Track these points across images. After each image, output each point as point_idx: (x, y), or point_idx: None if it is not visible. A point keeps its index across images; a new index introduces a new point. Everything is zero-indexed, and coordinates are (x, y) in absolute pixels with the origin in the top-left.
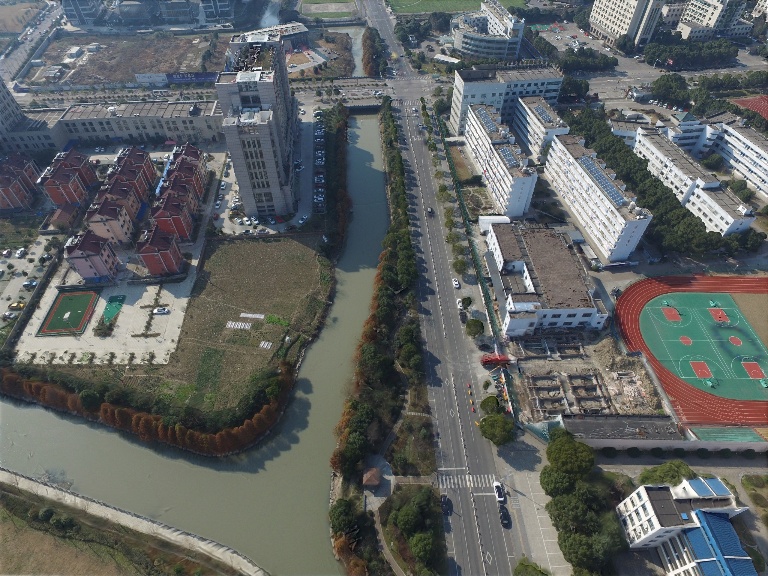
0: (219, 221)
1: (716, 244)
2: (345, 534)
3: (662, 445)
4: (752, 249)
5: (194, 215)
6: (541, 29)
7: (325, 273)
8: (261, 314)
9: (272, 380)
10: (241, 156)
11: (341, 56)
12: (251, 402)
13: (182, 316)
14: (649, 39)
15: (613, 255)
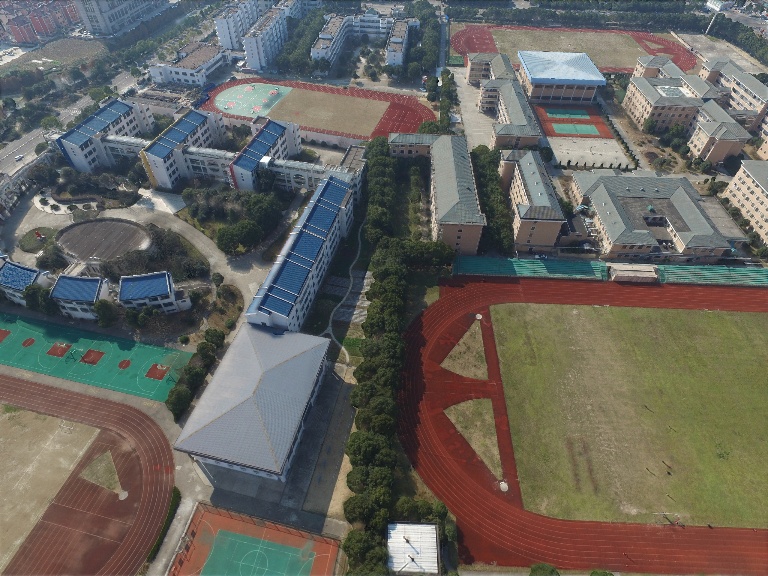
0: (72, 31)
1: (299, 62)
2: (3, 106)
3: (165, 112)
4: (337, 76)
5: (61, 27)
6: None
7: (99, 54)
8: (51, 60)
9: (24, 70)
10: None
11: None
12: (10, 75)
13: (18, 57)
14: None
15: (249, 65)
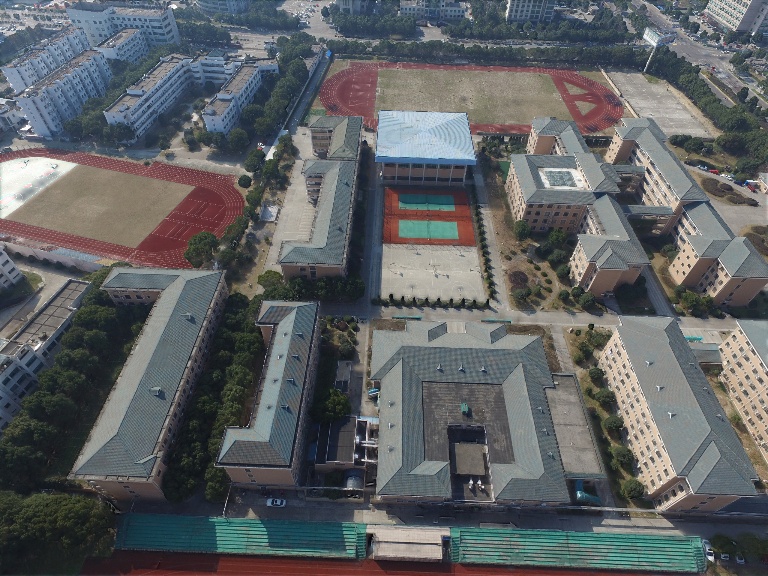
0: None
1: None
2: None
3: None
4: (145, 145)
5: None
6: None
7: None
8: None
9: None
10: None
11: None
12: None
13: None
14: (351, 10)
15: (35, 130)
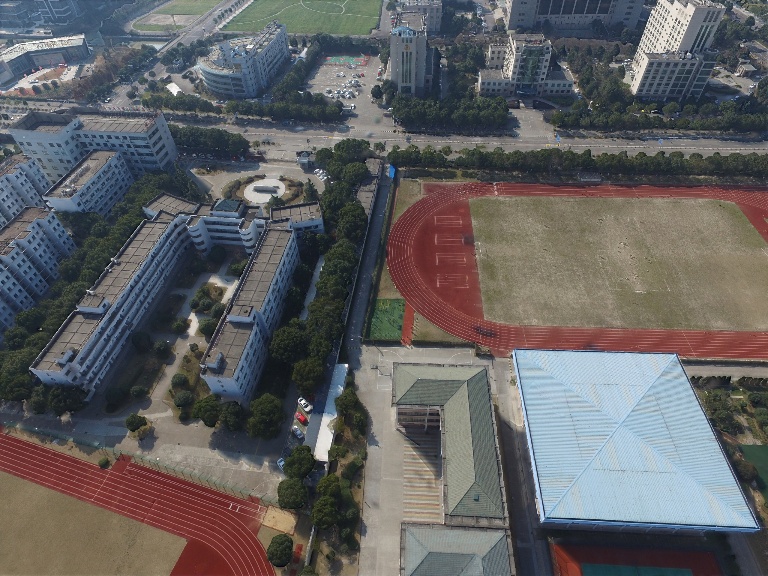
0: None
1: (8, 394)
2: None
3: None
4: (106, 407)
5: None
6: (340, 62)
7: None
8: None
9: None
10: None
11: (90, 75)
12: None
13: None
14: (413, 88)
15: None
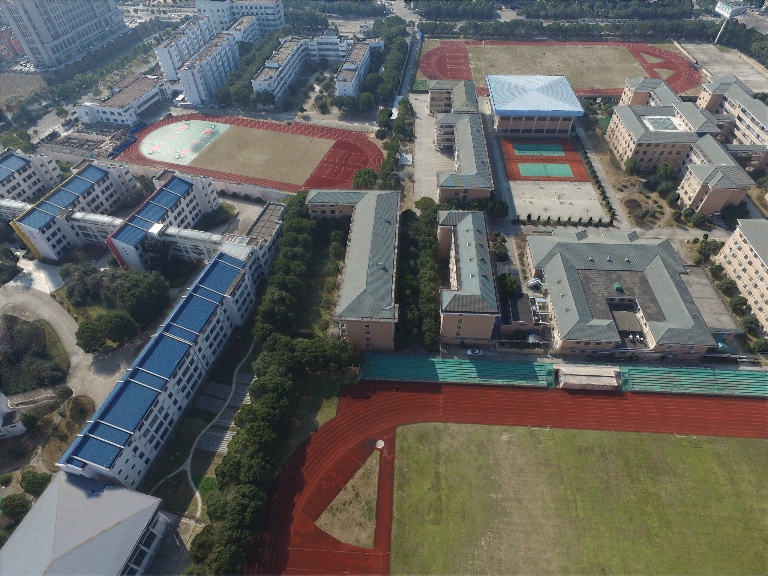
0: (16, 64)
1: (239, 95)
2: None
3: (78, 161)
4: (283, 109)
5: (6, 60)
6: None
7: (35, 90)
8: None
9: None
10: (12, 19)
11: None
12: None
13: None
14: None
15: (189, 99)
